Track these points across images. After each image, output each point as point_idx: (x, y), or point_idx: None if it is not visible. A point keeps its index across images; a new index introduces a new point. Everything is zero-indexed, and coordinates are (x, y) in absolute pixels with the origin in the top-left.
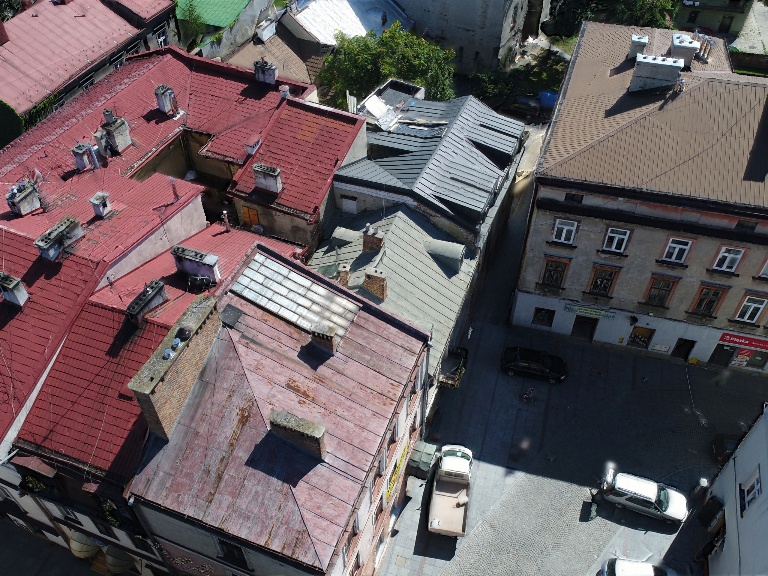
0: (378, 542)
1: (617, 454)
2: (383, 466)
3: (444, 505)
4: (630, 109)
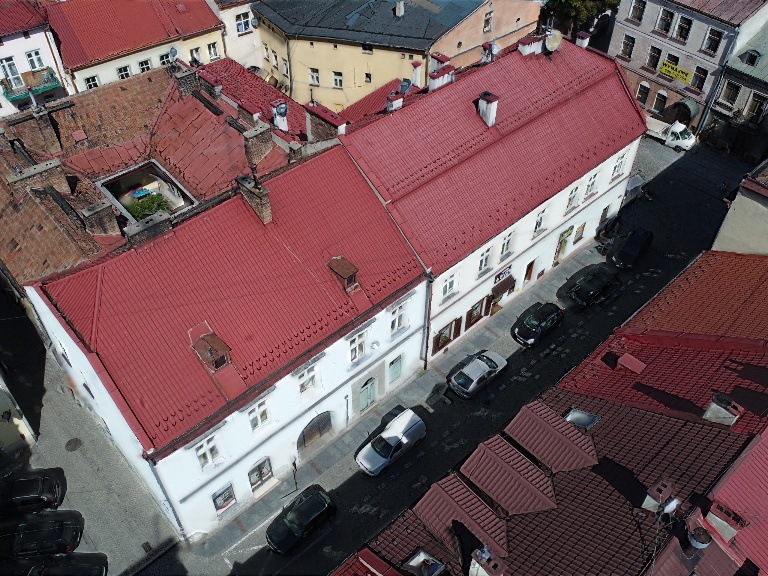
0: (645, 99)
1: (662, 206)
2: (671, 29)
3: (657, 127)
4: None
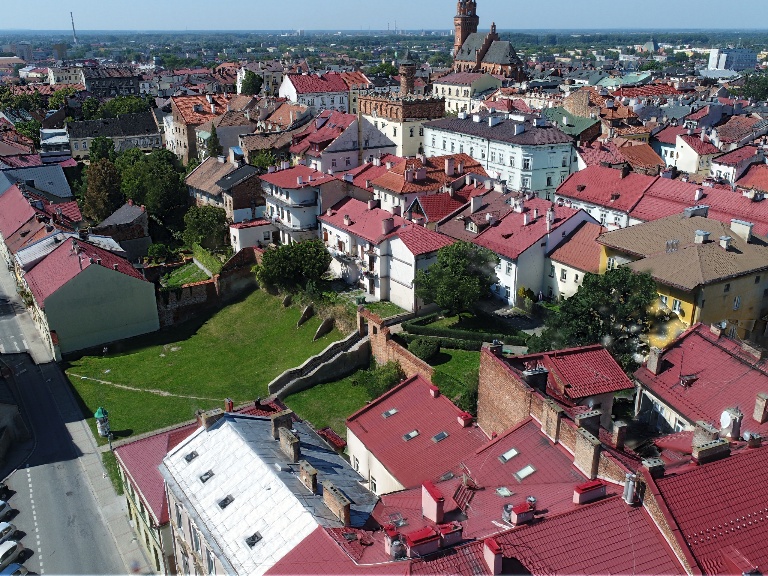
0: None
1: None
2: None
3: None
4: (759, 239)
